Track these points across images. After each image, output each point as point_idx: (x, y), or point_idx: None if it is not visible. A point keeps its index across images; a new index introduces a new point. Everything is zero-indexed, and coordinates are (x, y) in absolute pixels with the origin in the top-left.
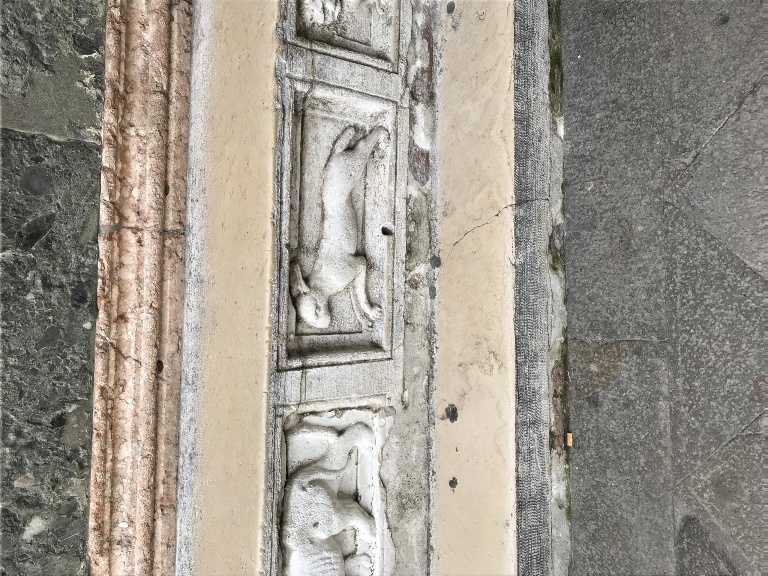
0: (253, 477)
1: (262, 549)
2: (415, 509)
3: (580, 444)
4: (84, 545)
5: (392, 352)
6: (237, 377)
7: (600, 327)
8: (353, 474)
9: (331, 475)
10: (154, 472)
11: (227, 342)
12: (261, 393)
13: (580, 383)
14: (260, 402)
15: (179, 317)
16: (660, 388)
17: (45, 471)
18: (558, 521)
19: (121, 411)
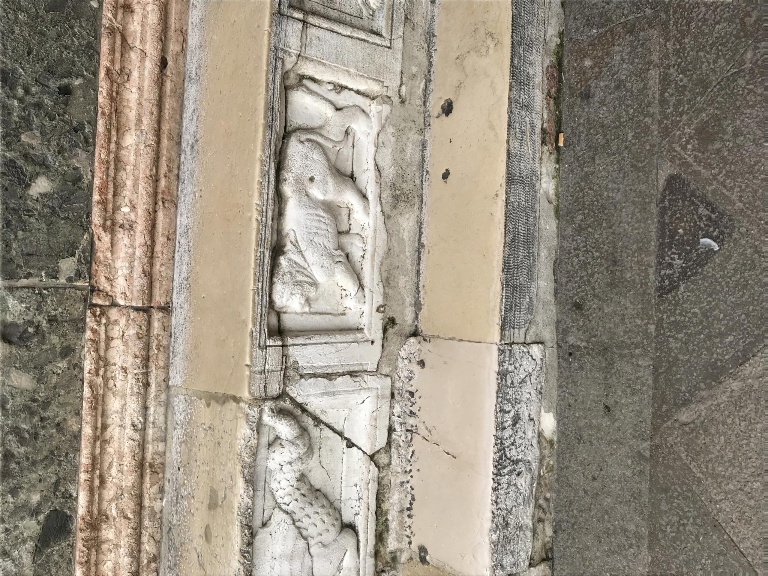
0: (252, 117)
1: (259, 181)
2: (408, 204)
3: (571, 141)
4: (87, 217)
5: (391, 41)
6: (240, 35)
7: (596, 19)
8: (349, 156)
9: (328, 141)
10: (156, 164)
11: (231, 9)
12: (263, 32)
13: (573, 81)
14: (261, 41)
15: (184, 18)
16: (651, 57)
17: (51, 132)
18: (546, 213)
19: (126, 99)
